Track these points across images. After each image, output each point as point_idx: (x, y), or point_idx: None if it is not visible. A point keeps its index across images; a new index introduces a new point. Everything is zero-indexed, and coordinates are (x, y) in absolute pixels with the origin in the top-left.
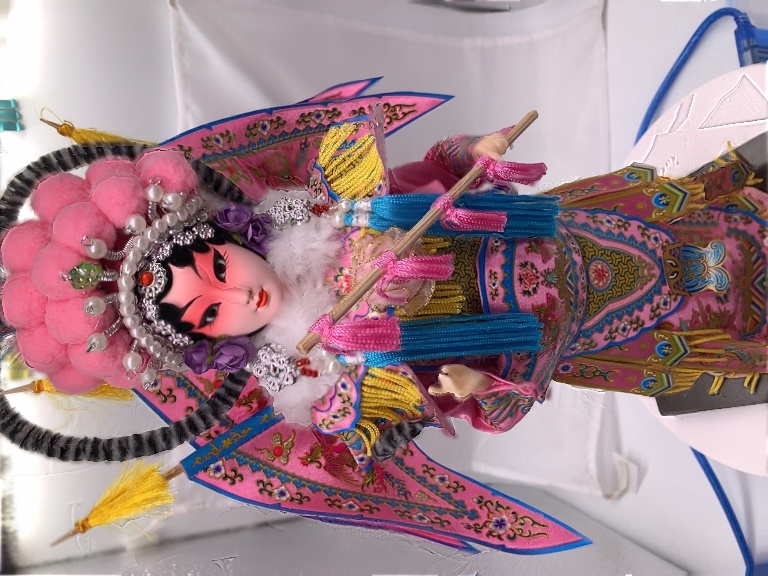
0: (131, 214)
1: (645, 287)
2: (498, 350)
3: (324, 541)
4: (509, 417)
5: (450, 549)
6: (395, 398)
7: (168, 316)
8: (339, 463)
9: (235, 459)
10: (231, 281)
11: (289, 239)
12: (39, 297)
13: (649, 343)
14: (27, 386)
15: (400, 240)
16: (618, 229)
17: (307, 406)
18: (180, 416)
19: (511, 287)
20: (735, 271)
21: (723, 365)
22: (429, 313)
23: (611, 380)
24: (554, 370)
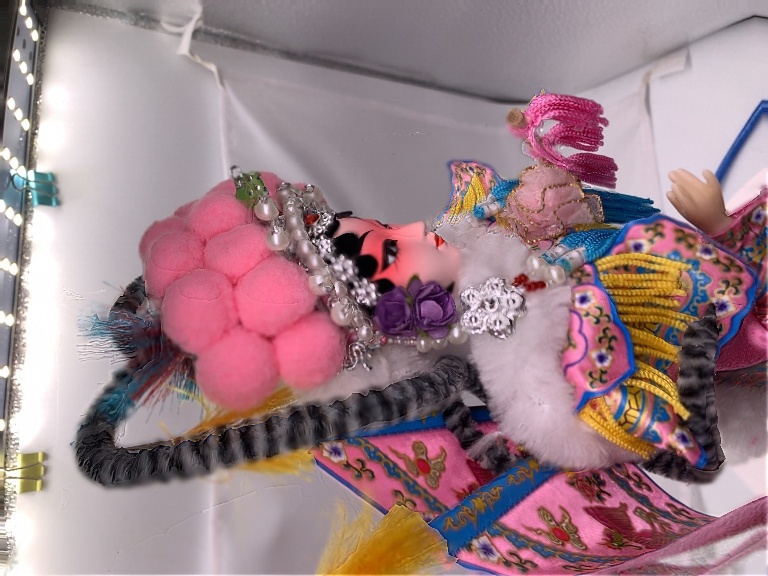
0: None
1: None
2: None
3: None
4: None
5: None
6: (652, 303)
7: (345, 248)
8: (663, 543)
9: (505, 538)
10: None
11: None
12: (196, 240)
13: None
14: (161, 441)
15: None
16: None
17: (557, 368)
18: (389, 502)
19: None
20: None
21: None
22: None
23: None
24: None
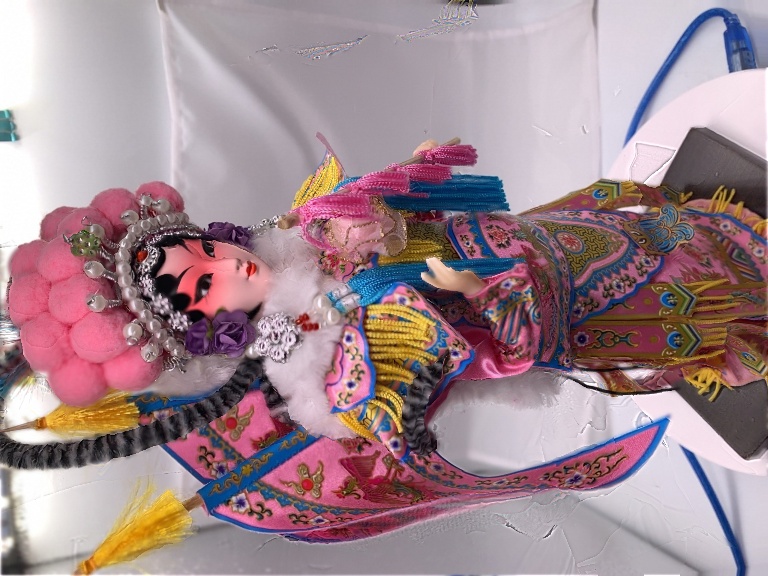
0: (125, 210)
1: (619, 250)
2: (488, 275)
3: (382, 568)
4: (523, 327)
5: (522, 500)
6: (404, 343)
7: (164, 288)
8: (380, 493)
9: (259, 492)
10: (220, 255)
11: (270, 238)
12: (43, 283)
13: (651, 298)
14: (29, 423)
15: None
16: (572, 216)
17: (320, 385)
18: (193, 456)
19: (485, 243)
20: (706, 247)
21: (740, 310)
22: (411, 260)
23: (635, 345)
24: (569, 336)
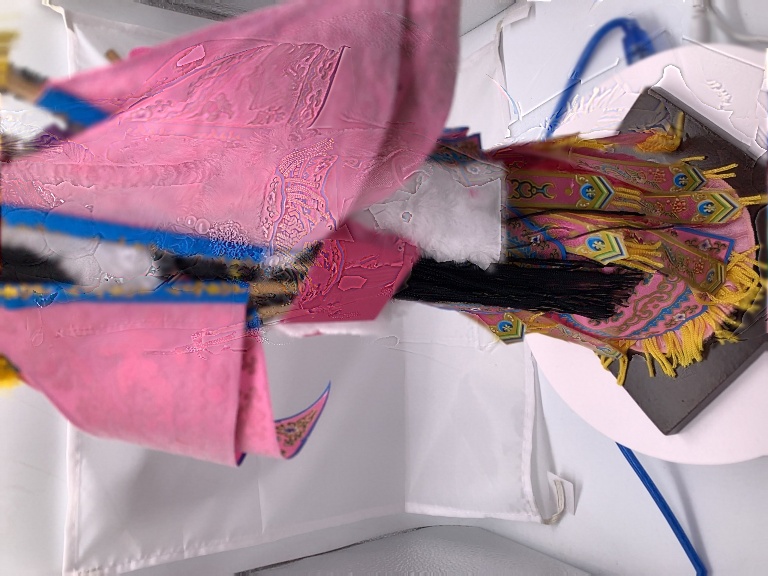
0: None
1: None
2: None
3: None
4: None
5: None
6: None
7: None
8: None
9: None
10: None
11: None
12: None
13: None
14: None
15: (276, 325)
16: None
17: None
18: None
19: None
20: None
21: None
22: None
23: None
24: None
